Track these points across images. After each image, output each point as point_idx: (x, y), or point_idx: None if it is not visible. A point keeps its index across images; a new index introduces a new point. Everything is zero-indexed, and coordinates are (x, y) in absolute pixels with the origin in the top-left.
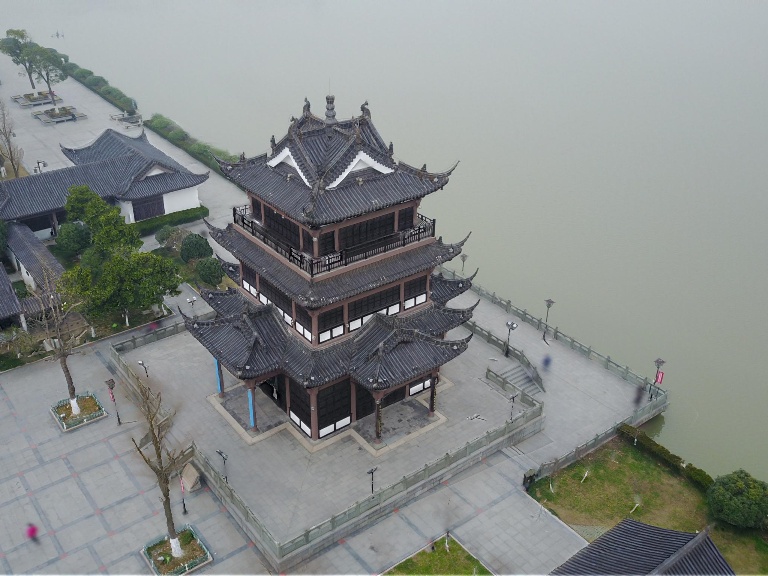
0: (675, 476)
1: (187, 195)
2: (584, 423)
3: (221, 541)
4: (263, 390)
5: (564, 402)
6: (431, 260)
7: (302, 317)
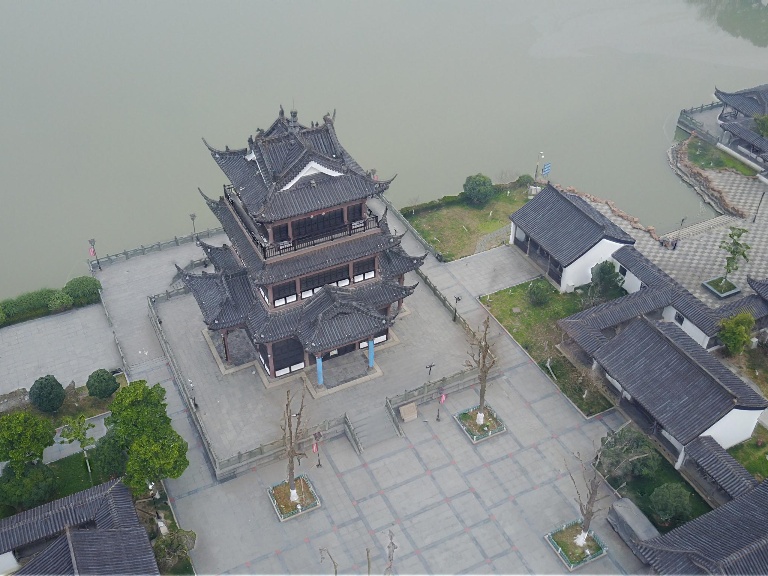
0: (441, 209)
1: None
2: None
3: (469, 401)
4: (322, 361)
5: None
6: None
7: (361, 268)
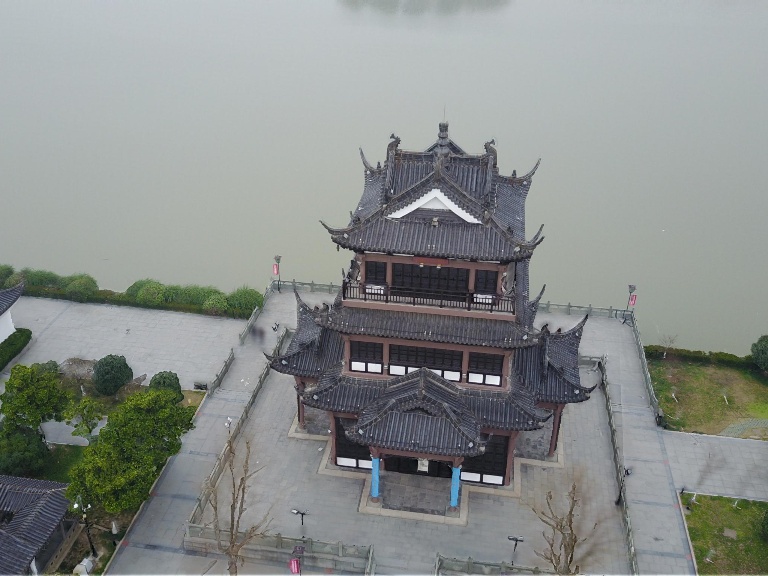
0: (708, 366)
1: (3, 321)
2: (616, 361)
3: None
4: (402, 471)
5: (583, 353)
6: (523, 263)
7: (481, 365)
